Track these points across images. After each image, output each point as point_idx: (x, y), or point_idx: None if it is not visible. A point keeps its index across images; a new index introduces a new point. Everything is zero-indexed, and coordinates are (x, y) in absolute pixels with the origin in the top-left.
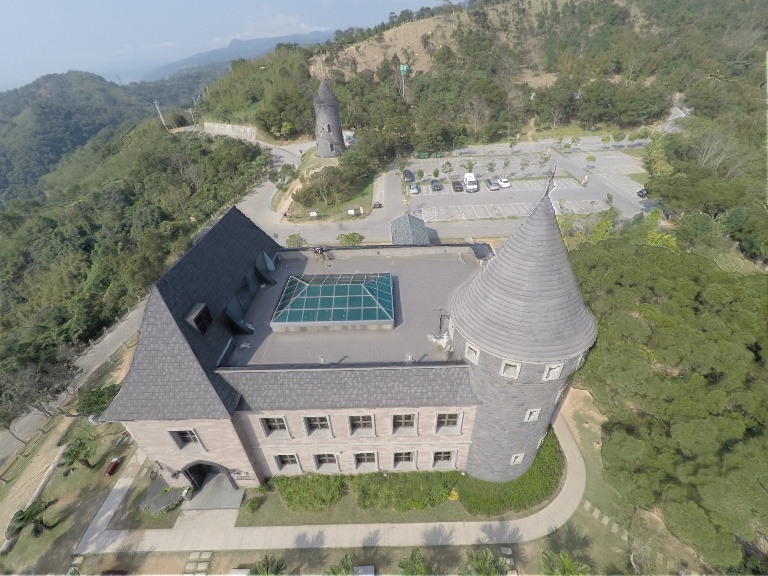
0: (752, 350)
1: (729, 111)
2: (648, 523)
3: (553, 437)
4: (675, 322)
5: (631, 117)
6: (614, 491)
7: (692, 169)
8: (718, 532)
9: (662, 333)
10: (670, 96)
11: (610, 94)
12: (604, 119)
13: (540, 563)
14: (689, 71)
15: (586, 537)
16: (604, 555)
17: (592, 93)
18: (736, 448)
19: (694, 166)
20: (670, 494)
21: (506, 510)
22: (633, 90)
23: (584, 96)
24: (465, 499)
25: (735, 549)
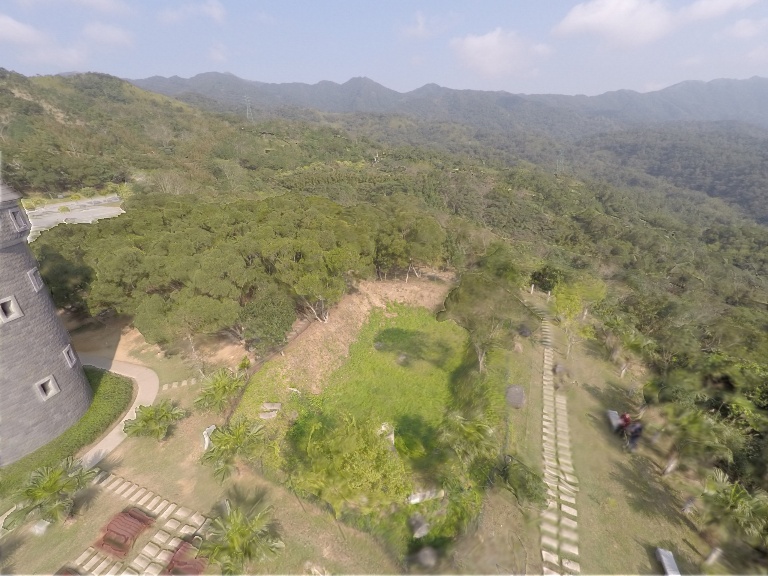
0: (206, 229)
1: (170, 169)
2: (215, 362)
3: (110, 374)
4: (155, 237)
5: (93, 181)
6: (184, 366)
7: (157, 195)
8: (222, 302)
9: (149, 246)
10: (119, 162)
11: (55, 162)
12: (67, 187)
13: (136, 448)
14: (129, 151)
15: (173, 402)
16: (192, 399)
17: (32, 162)
18: (203, 254)
19: (157, 193)
20: (186, 304)
21: (75, 449)
22: (80, 159)
23: (23, 165)
24: (4, 487)
25: (233, 302)
